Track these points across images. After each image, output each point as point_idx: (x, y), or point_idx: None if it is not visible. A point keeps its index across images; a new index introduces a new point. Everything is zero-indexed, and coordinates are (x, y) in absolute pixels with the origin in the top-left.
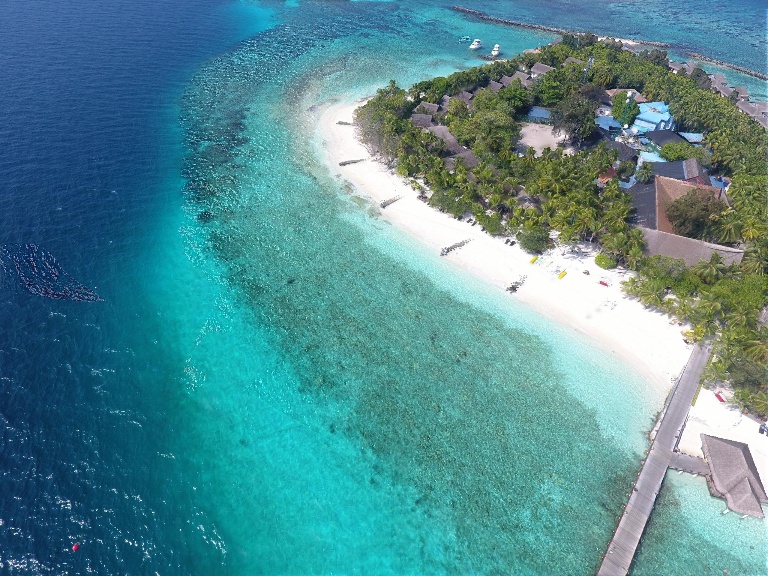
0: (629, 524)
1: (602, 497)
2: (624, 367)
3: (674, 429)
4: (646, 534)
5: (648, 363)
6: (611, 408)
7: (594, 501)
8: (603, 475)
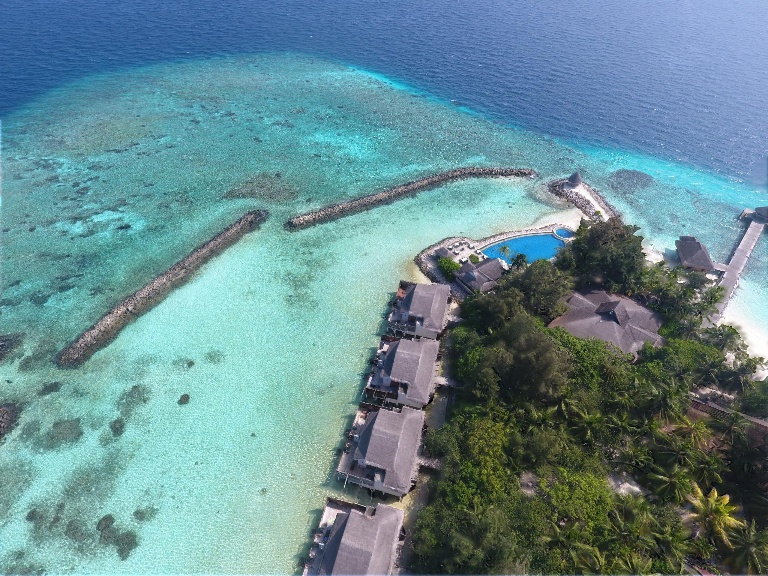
0: (749, 246)
1: (760, 263)
2: (766, 332)
3: (726, 282)
4: (732, 248)
5: (747, 332)
6: (767, 305)
7: (765, 262)
8: (762, 272)
